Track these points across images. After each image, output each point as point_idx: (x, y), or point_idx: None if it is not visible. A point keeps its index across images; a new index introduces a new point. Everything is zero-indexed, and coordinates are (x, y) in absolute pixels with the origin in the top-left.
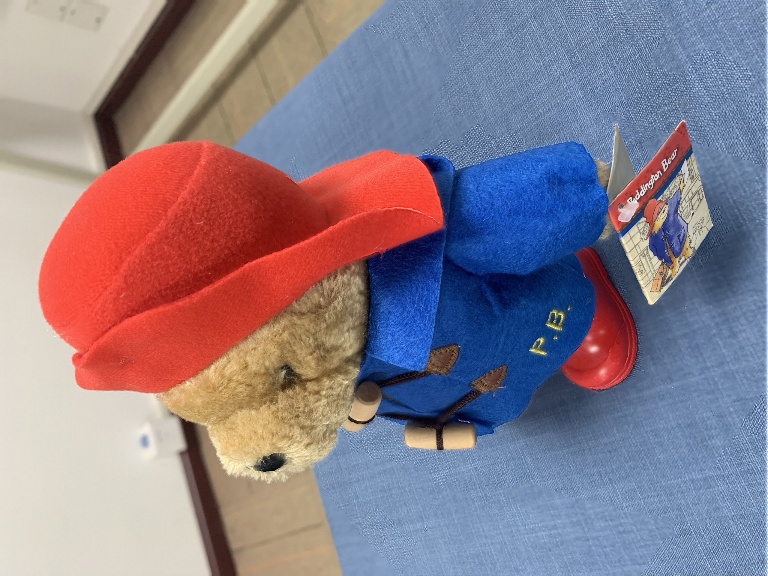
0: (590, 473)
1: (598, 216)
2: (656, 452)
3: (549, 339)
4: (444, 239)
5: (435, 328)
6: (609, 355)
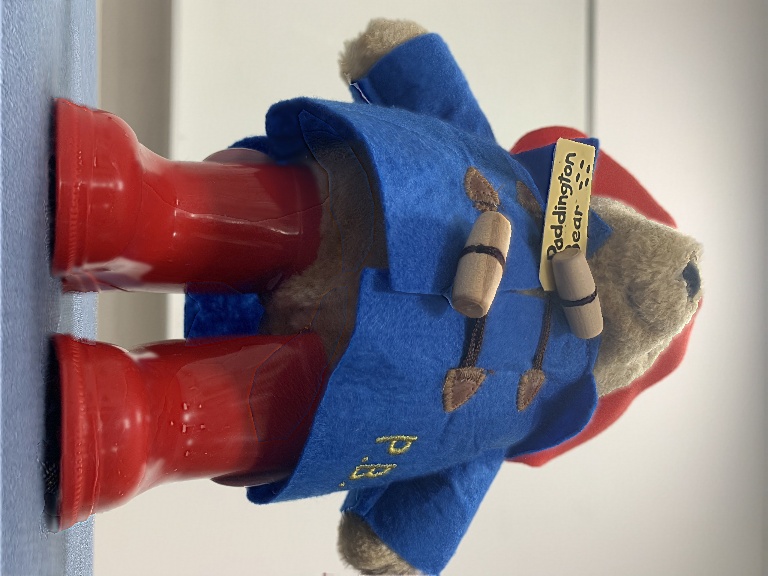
0: (1, 275)
1: (435, 569)
2: (3, 562)
3: (376, 455)
4: (519, 455)
5: (534, 409)
6: (141, 480)
